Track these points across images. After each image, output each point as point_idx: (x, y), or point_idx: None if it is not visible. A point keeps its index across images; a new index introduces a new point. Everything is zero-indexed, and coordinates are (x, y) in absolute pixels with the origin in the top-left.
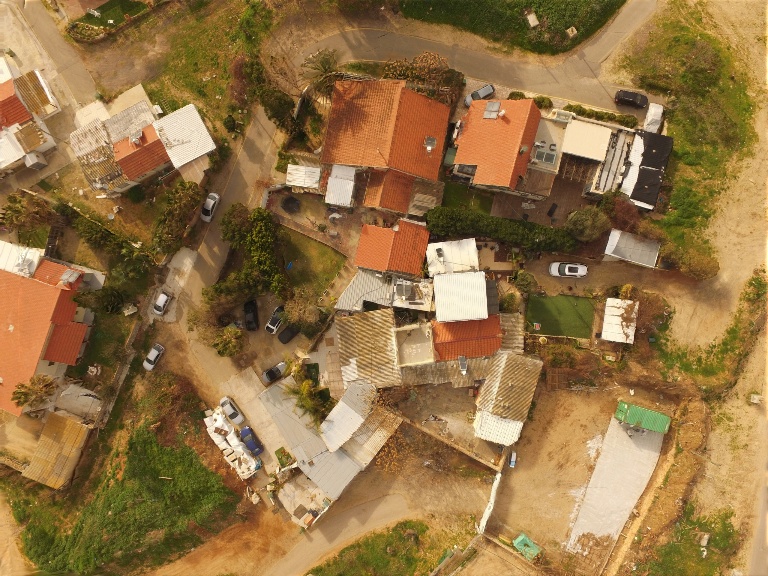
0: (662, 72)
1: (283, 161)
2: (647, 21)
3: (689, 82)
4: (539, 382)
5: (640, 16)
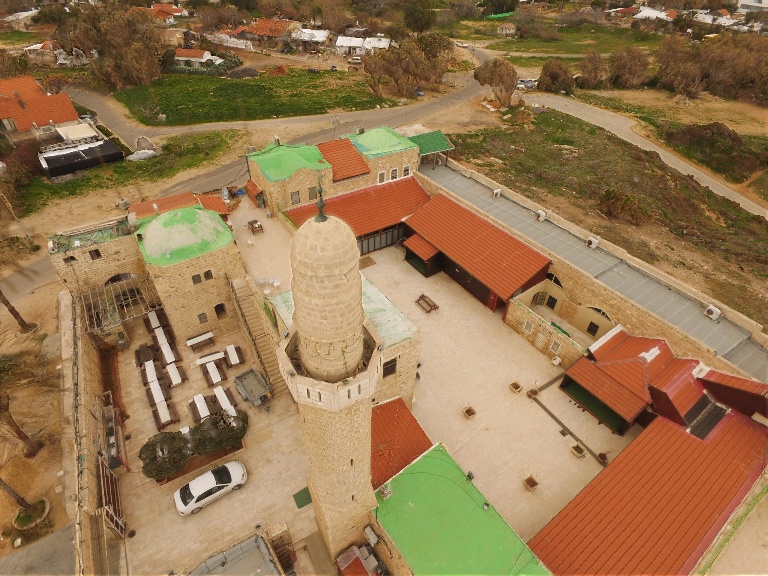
0: (182, 145)
1: None
2: (208, 130)
3: None
4: None
5: (208, 128)
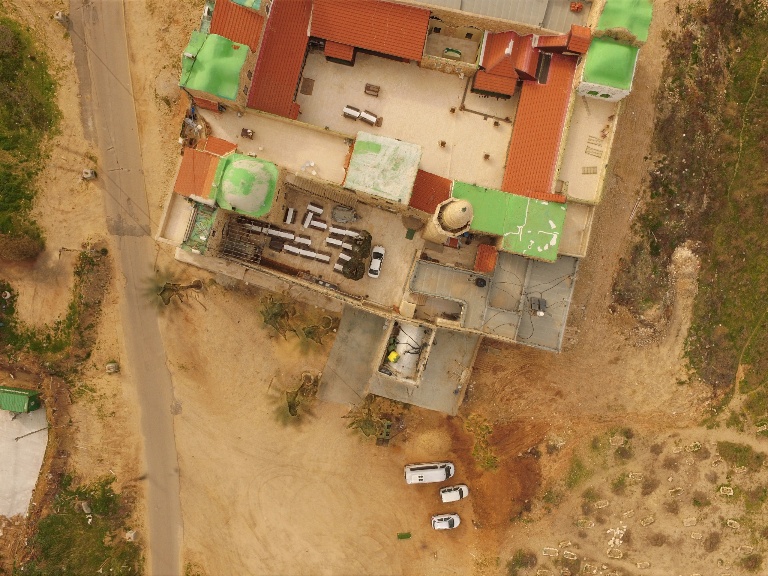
0: None
1: None
2: None
3: (0, 68)
4: None
5: None
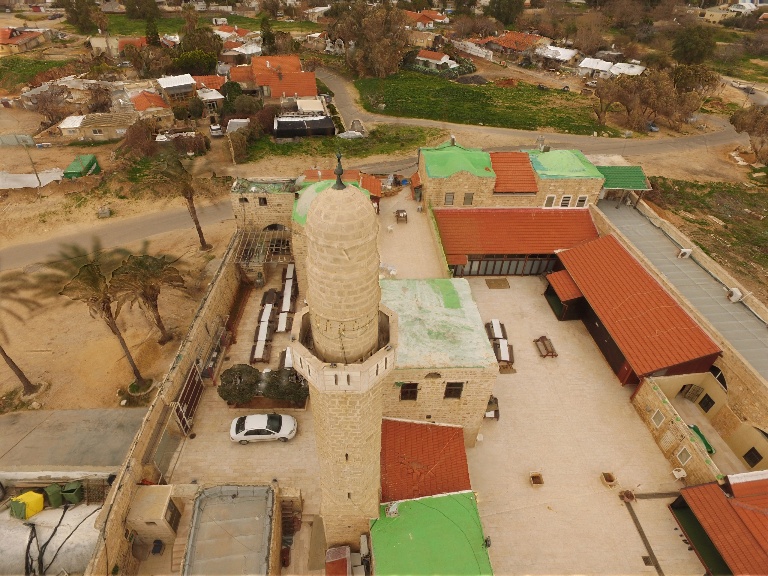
0: (386, 133)
1: None
2: None
3: None
4: None
5: None
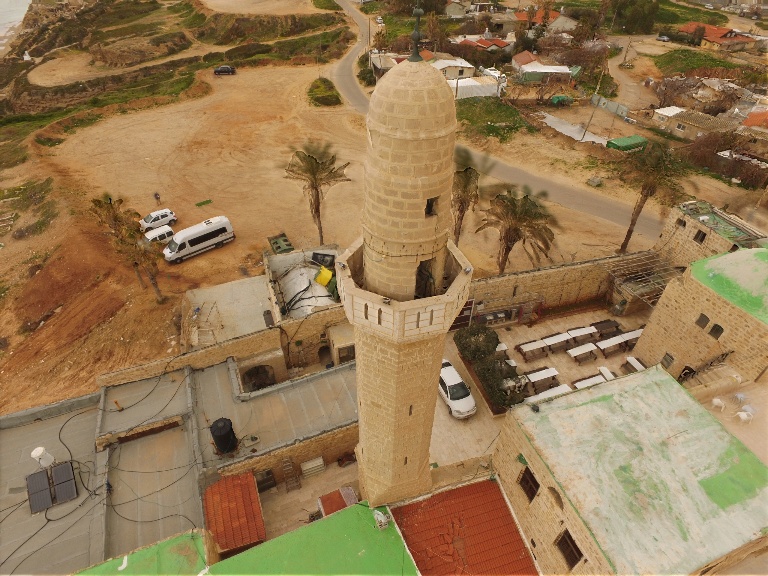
0: None
1: None
2: None
3: None
4: None
5: None
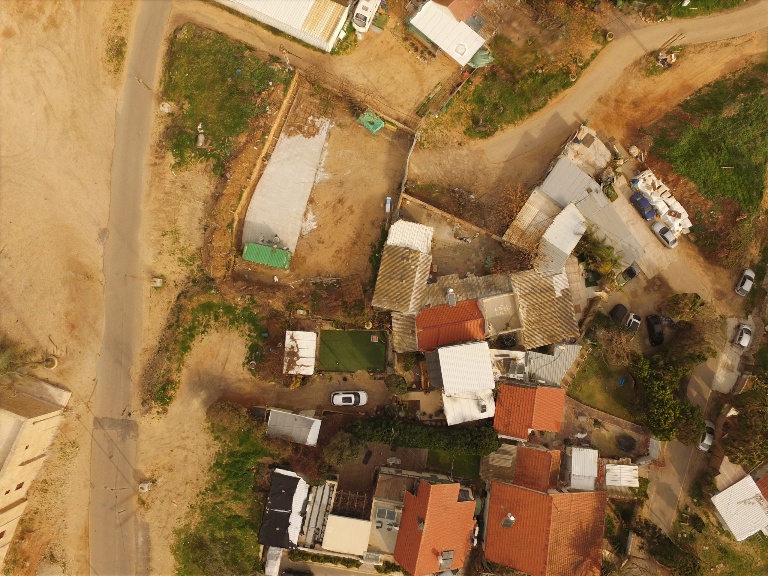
0: None
1: (643, 490)
2: None
3: None
4: (367, 283)
5: None
